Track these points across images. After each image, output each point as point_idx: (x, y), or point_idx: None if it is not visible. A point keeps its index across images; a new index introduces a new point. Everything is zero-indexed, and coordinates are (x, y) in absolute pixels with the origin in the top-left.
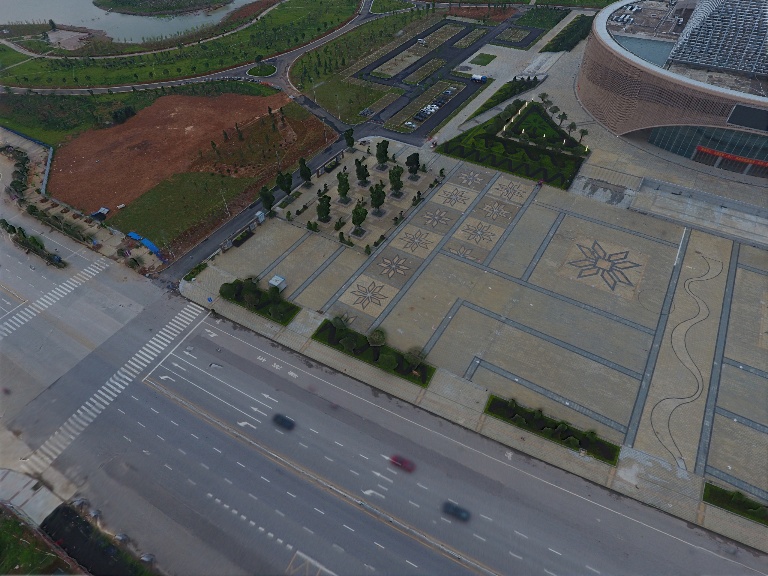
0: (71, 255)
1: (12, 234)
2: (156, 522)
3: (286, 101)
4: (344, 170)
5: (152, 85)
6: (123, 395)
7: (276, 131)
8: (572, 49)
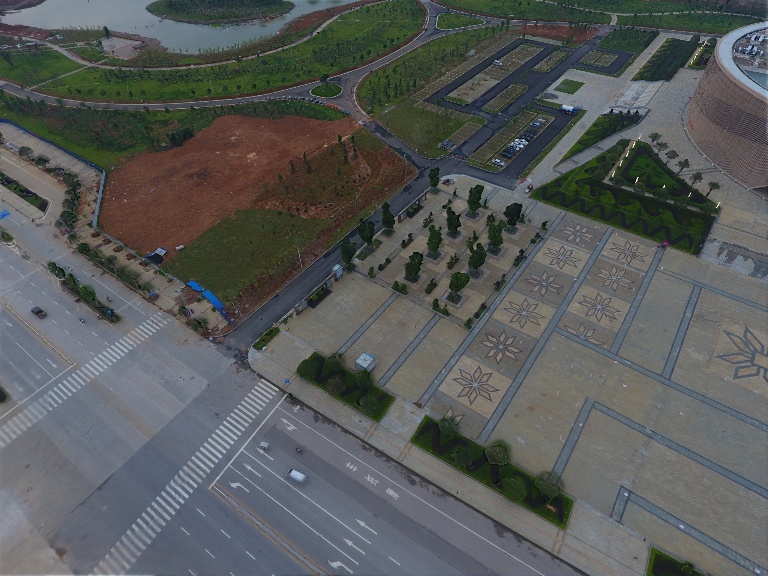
0: (125, 306)
1: (61, 278)
2: None
3: (355, 127)
4: (430, 216)
5: (210, 102)
6: (187, 507)
7: (347, 163)
8: (671, 79)
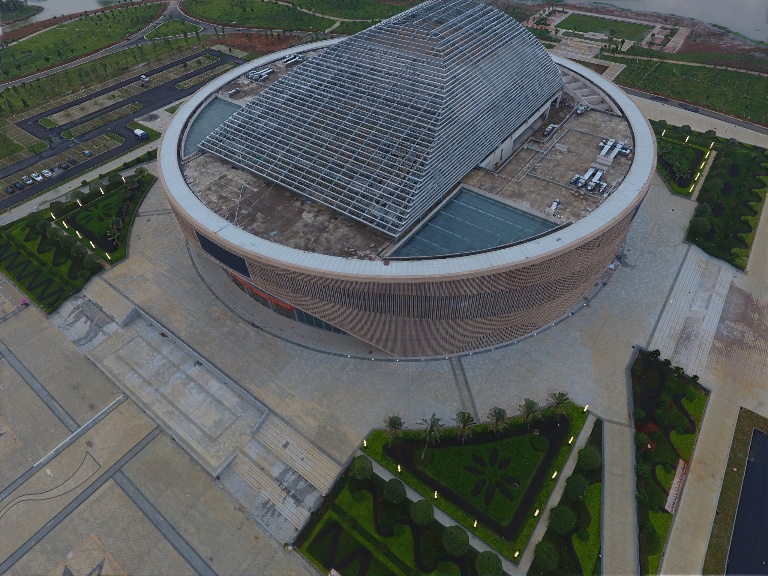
0: None
1: None
2: None
3: None
4: None
5: None
6: None
7: None
8: None
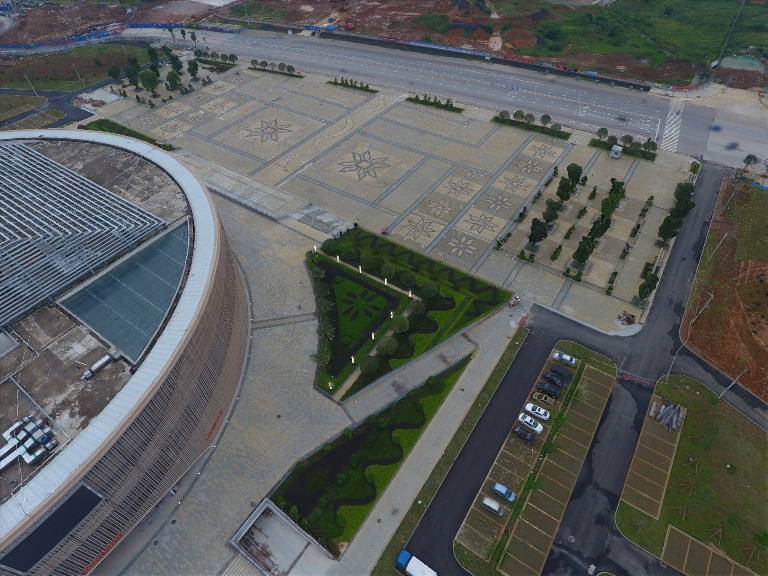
0: None
1: None
2: (602, 88)
3: None
4: None
5: None
6: None
7: None
8: None
